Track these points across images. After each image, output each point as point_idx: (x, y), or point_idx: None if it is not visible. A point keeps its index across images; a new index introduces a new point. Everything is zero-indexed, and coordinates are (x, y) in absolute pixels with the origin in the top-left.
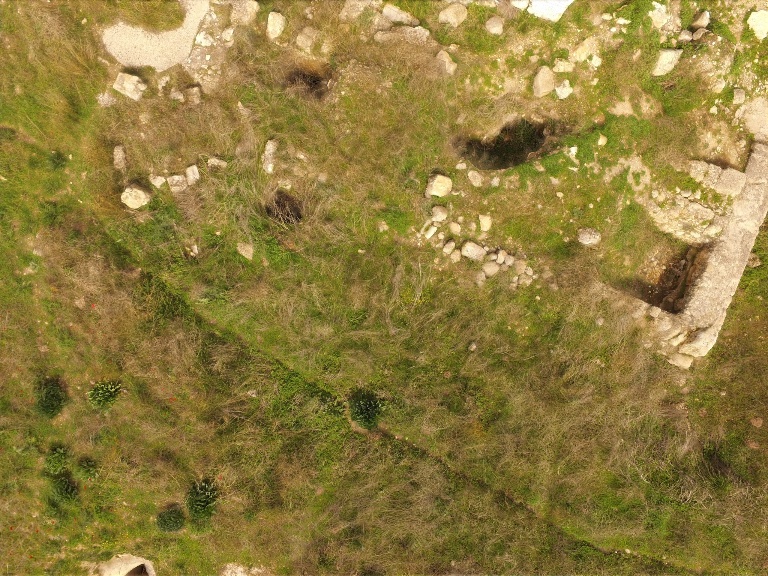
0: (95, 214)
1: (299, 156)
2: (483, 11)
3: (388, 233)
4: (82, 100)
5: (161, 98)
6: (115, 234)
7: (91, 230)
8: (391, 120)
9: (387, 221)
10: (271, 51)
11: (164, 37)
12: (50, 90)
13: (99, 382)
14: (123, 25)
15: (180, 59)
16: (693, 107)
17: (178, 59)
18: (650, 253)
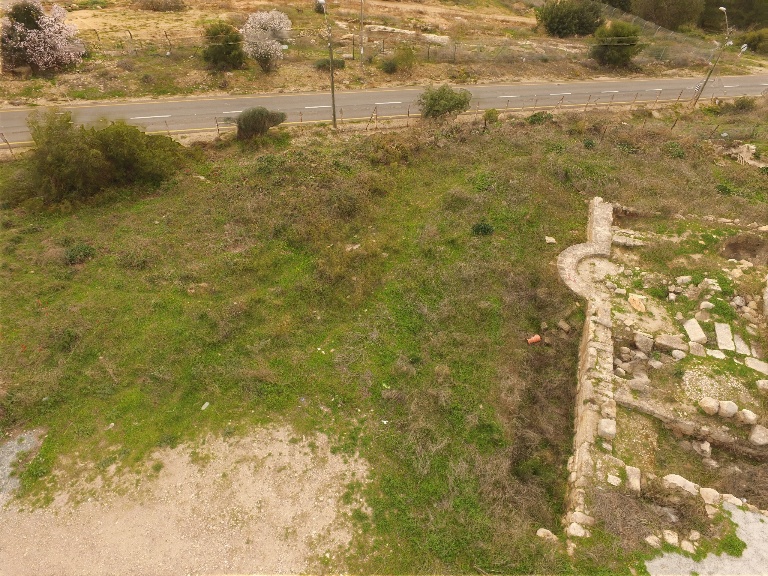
0: None
1: None
2: None
3: None
4: None
5: None
6: None
7: None
8: None
9: None
10: None
11: None
12: None
13: None
14: None
15: None
16: None
17: None
18: None
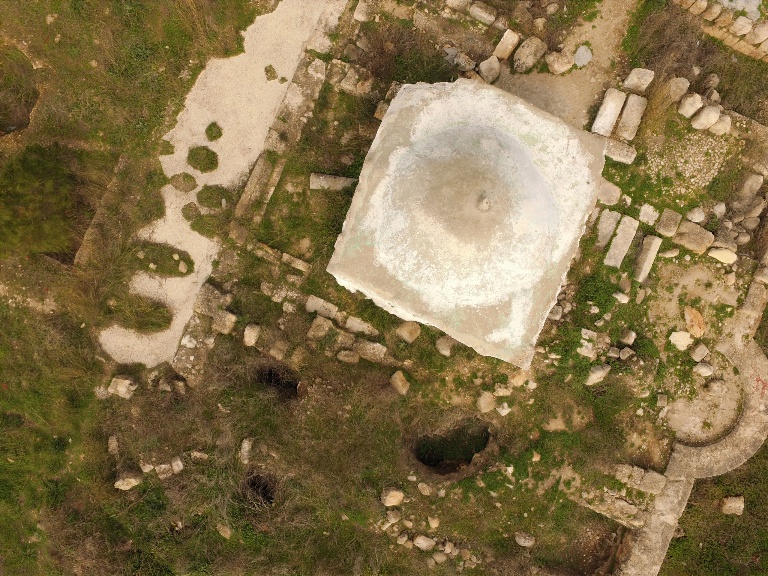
0: (92, 491)
1: (271, 454)
2: (434, 332)
3: (349, 522)
4: (81, 395)
5: (150, 390)
6: (109, 510)
7: (88, 508)
8: (350, 438)
9: (348, 516)
10: (248, 353)
11: (153, 338)
12: (52, 387)
13: None
14: (117, 327)
15: (167, 357)
16: (621, 410)
17: (166, 357)
18: None
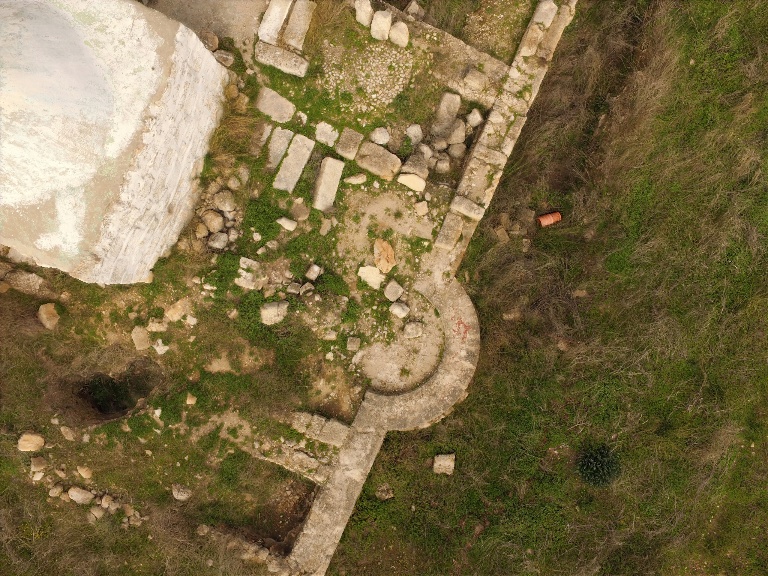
0: None
1: None
2: None
3: (3, 471)
4: None
5: None
6: None
7: None
8: None
9: None
10: None
11: None
12: None
13: None
14: None
15: None
16: (307, 354)
17: None
18: (284, 483)
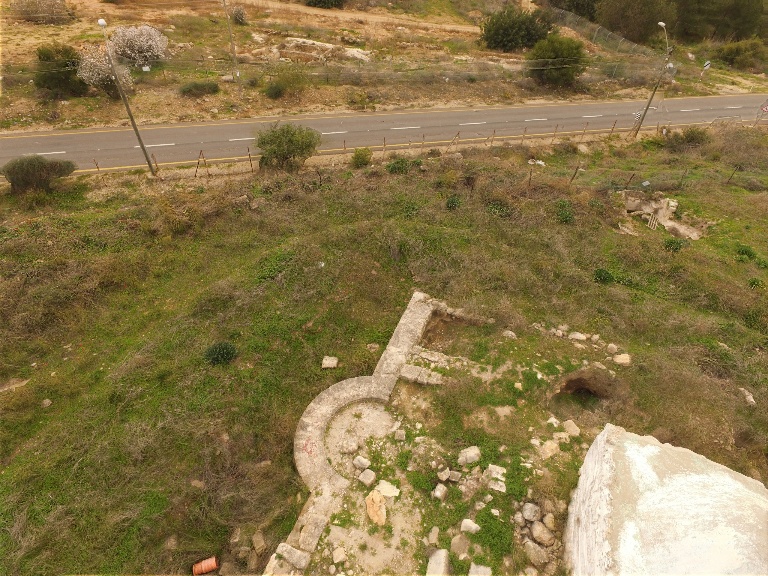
0: None
1: None
2: None
3: None
4: None
5: None
6: None
7: None
8: None
9: None
10: None
11: None
12: None
13: (765, 288)
14: None
15: None
16: None
17: None
18: None
